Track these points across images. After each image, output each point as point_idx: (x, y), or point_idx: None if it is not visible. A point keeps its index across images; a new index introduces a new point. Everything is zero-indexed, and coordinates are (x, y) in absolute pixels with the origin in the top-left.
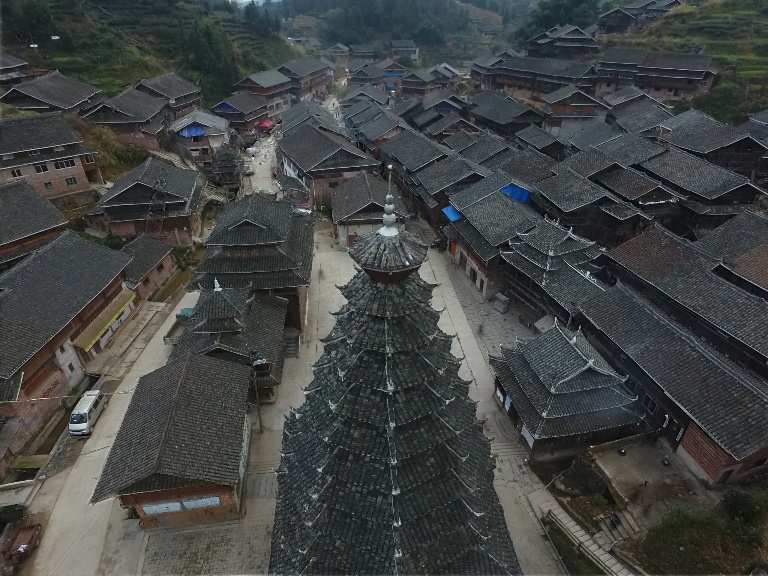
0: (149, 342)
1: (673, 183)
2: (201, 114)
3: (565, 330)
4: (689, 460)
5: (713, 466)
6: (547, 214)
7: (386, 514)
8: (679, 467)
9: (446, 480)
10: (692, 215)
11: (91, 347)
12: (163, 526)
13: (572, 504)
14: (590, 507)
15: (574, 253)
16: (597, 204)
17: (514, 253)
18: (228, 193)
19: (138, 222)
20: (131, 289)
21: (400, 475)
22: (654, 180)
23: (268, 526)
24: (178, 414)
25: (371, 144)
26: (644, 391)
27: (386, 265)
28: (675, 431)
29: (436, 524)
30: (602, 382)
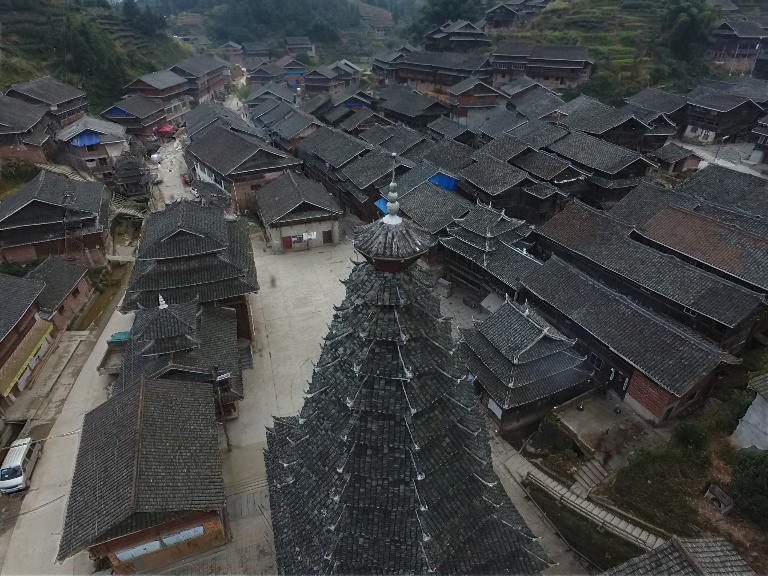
0: (78, 376)
1: (579, 162)
2: (92, 120)
3: (516, 304)
4: (636, 405)
5: (658, 406)
6: (475, 199)
7: (411, 501)
8: (628, 413)
9: (460, 457)
10: (598, 190)
11: (10, 391)
12: (141, 570)
13: (546, 463)
14: (563, 462)
15: (507, 233)
16: (519, 186)
17: (452, 238)
18: (139, 204)
19: (39, 245)
20: (46, 320)
21: (421, 460)
22: (564, 160)
23: (259, 545)
24: (145, 445)
25: (287, 143)
26: (590, 350)
27: (398, 253)
28: (621, 382)
29: (455, 502)
30: (556, 347)
